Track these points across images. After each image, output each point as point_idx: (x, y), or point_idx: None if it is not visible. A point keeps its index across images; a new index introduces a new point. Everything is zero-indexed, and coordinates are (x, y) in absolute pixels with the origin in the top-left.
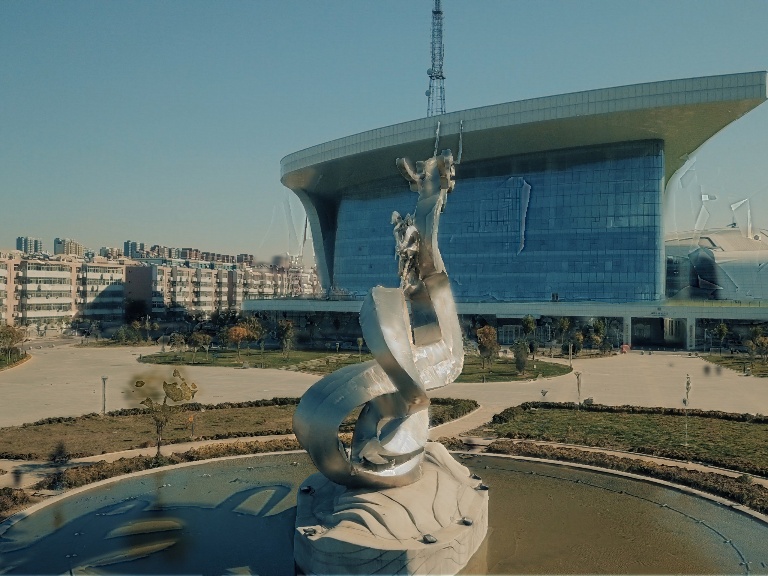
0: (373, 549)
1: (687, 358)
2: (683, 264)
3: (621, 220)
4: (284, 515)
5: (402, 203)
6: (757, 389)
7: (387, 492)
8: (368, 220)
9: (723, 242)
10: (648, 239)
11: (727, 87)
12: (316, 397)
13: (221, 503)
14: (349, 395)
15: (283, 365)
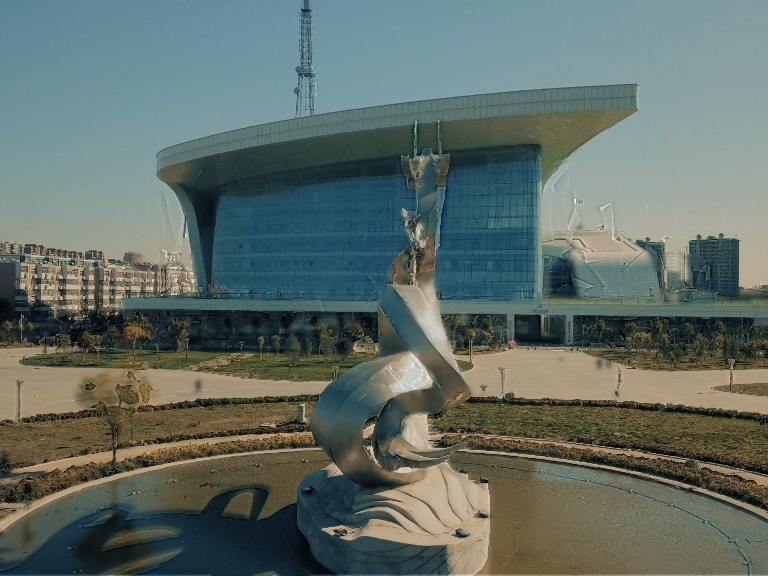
0: (414, 546)
1: (571, 353)
2: (558, 264)
3: (502, 221)
4: (277, 517)
5: (285, 201)
6: (650, 380)
7: (404, 489)
8: (249, 217)
9: (593, 243)
10: (527, 240)
11: (602, 97)
12: (337, 395)
13: (204, 508)
14: (371, 393)
15: (183, 365)
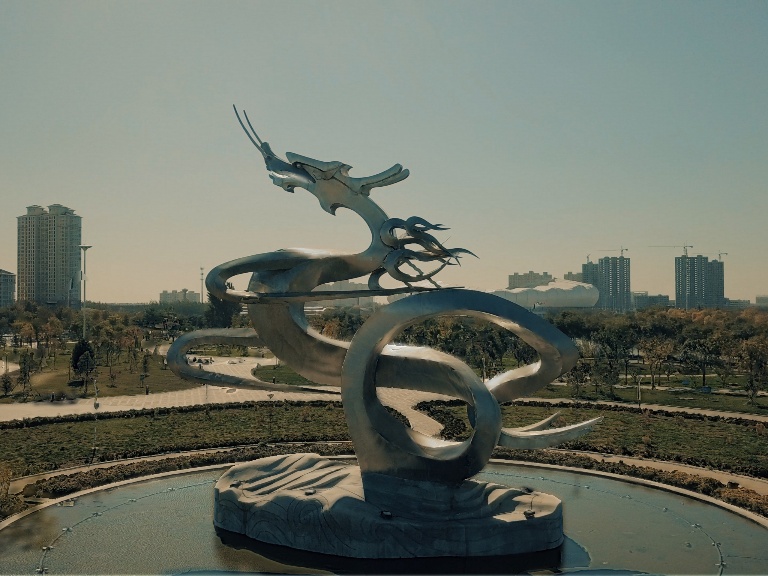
0: None
1: None
2: None
3: None
4: (331, 568)
5: None
6: None
7: None
8: None
9: None
10: None
11: None
12: None
13: None
14: None
15: None
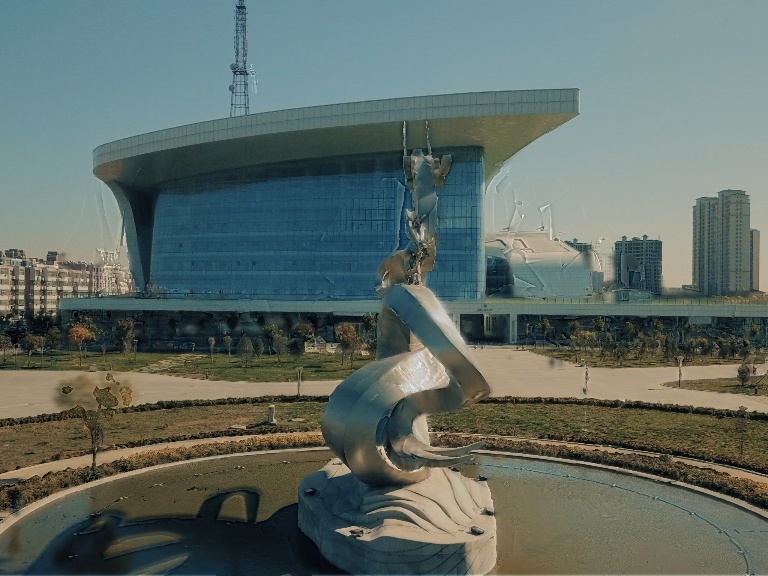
0: (434, 544)
1: (517, 351)
2: (501, 264)
3: (446, 222)
4: (275, 520)
5: (226, 199)
6: (601, 378)
7: (412, 488)
8: (189, 216)
9: (533, 244)
10: (471, 240)
11: (545, 101)
12: (348, 396)
13: (198, 512)
14: (383, 393)
15: (132, 367)
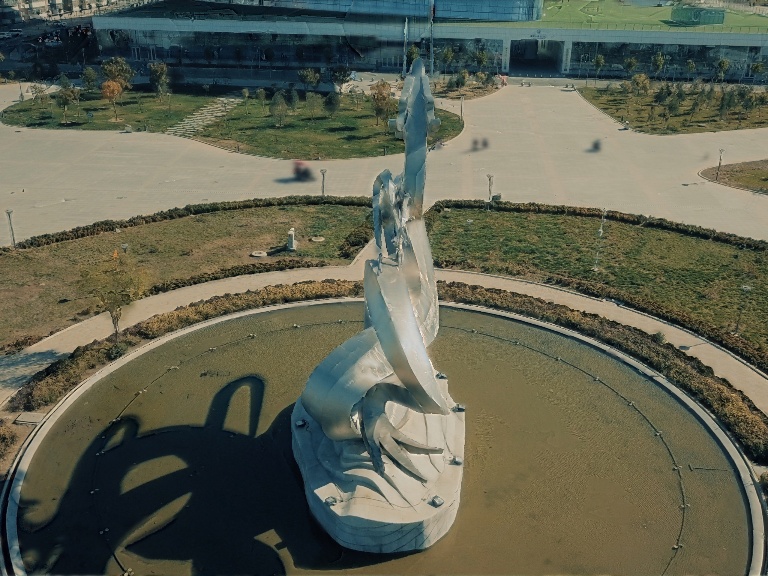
0: (395, 524)
1: (565, 93)
2: None
3: None
4: (274, 432)
5: None
6: (639, 157)
7: None
8: None
9: None
10: None
11: None
12: (325, 380)
13: (207, 417)
14: (358, 378)
15: (167, 125)
